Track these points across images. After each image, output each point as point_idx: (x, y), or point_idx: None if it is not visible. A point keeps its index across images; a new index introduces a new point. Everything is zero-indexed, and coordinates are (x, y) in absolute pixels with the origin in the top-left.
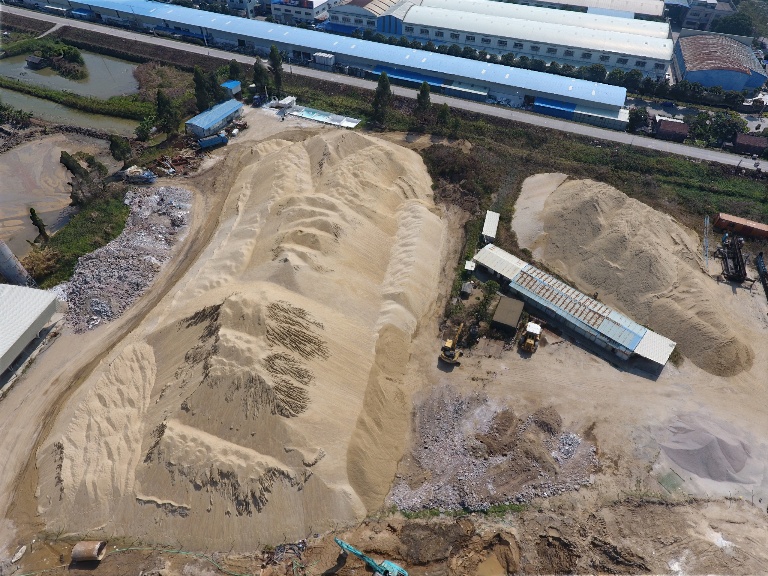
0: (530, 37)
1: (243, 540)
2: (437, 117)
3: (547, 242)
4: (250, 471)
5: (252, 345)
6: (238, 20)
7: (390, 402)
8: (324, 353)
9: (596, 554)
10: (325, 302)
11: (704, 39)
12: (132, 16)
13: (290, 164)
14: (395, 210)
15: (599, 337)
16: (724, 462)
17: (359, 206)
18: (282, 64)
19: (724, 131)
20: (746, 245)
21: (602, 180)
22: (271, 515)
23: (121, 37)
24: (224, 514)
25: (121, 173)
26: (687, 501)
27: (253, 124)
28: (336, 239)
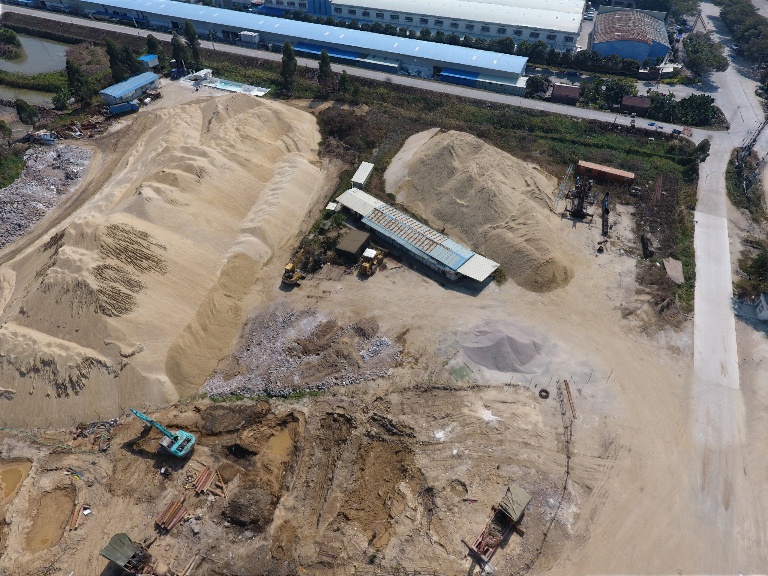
0: (449, 14)
1: (60, 418)
2: (338, 84)
3: (409, 186)
4: (69, 359)
5: (85, 257)
6: (173, 4)
7: (221, 312)
8: (161, 269)
9: (374, 427)
10: (174, 230)
11: (619, 15)
12: (73, 2)
13: (180, 122)
14: (274, 161)
15: (430, 260)
16: (511, 356)
17: (232, 154)
18: (208, 42)
19: (612, 94)
20: (599, 188)
21: (482, 136)
22: (87, 397)
23: (59, 21)
24: (44, 396)
25: (29, 136)
26: (469, 387)
27: (167, 94)
28: (198, 179)
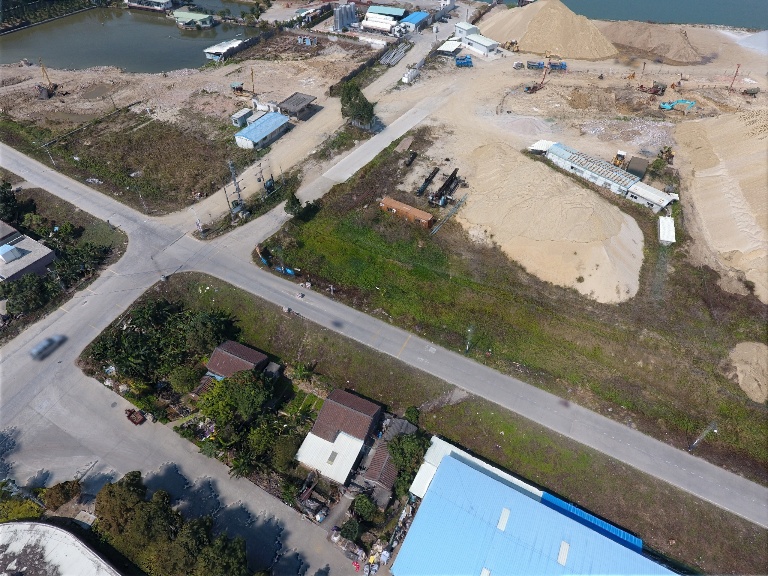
0: None
1: None
2: None
3: None
4: None
5: None
6: None
7: None
8: None
9: None
10: None
11: None
12: None
13: None
14: None
15: None
16: None
17: None
18: None
19: (270, 379)
20: (416, 207)
21: None
22: None
23: None
24: None
25: None
26: (545, 116)
27: None
28: None
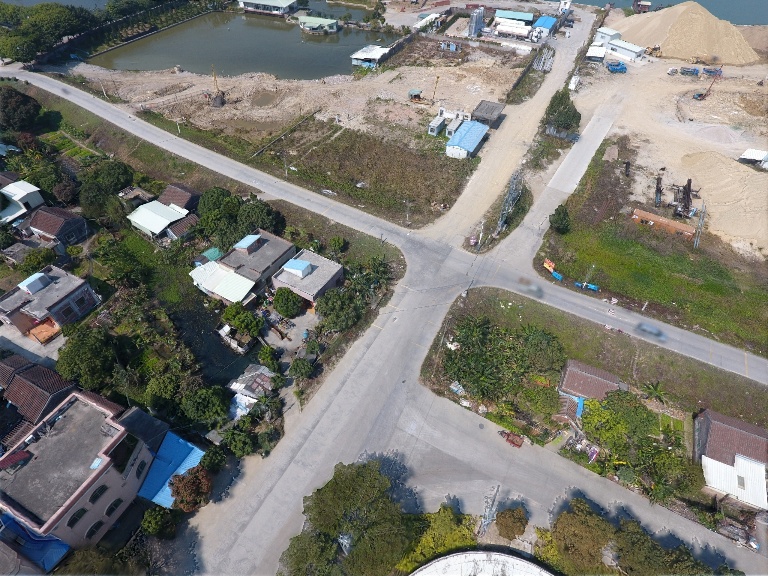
0: None
1: None
2: None
3: None
4: None
5: None
6: None
7: None
8: None
9: None
10: None
11: None
12: None
13: None
14: None
15: None
16: None
17: None
18: None
19: None
20: None
21: None
22: None
23: None
24: None
25: None
26: (729, 123)
27: None
28: None
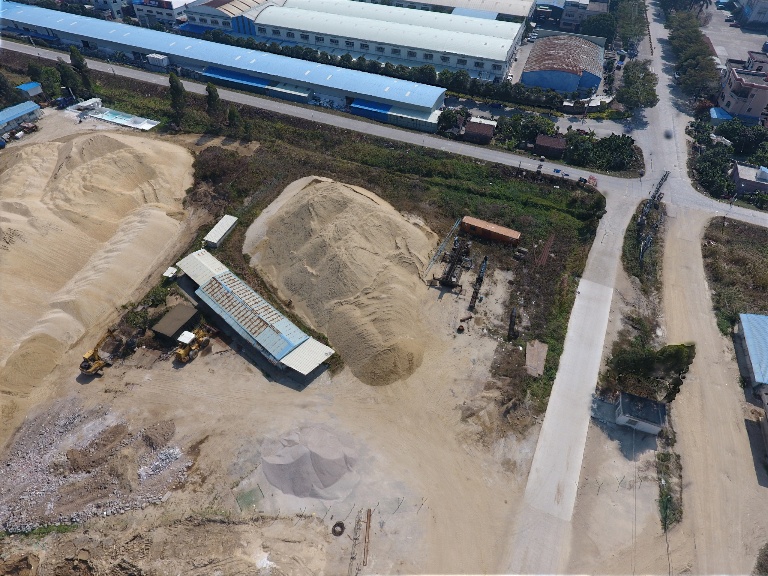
0: (374, 38)
1: None
2: None
3: (266, 247)
4: None
5: None
6: (85, 21)
7: None
8: None
9: None
10: None
11: (557, 40)
12: None
13: (26, 168)
14: (124, 215)
15: (255, 346)
16: (312, 477)
17: (64, 211)
18: (111, 65)
19: (527, 132)
20: (482, 249)
21: (372, 183)
22: None
23: None
24: None
25: None
26: (252, 519)
27: (46, 127)
28: (5, 246)
